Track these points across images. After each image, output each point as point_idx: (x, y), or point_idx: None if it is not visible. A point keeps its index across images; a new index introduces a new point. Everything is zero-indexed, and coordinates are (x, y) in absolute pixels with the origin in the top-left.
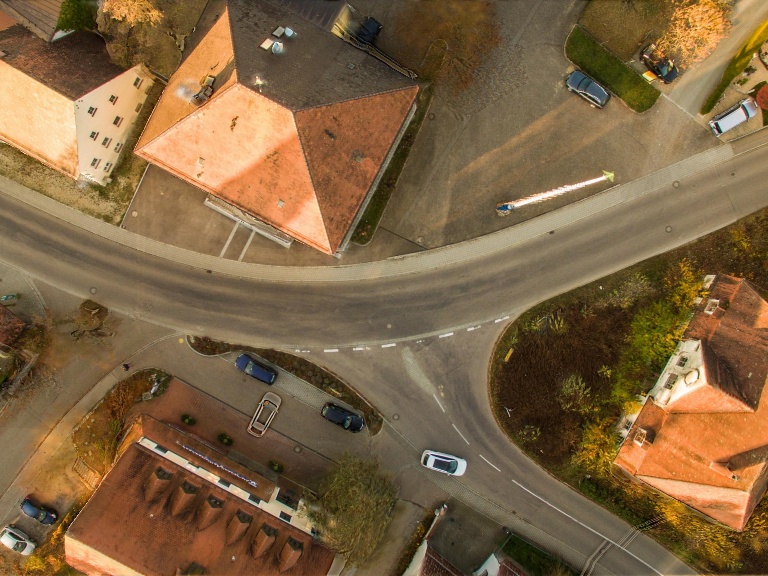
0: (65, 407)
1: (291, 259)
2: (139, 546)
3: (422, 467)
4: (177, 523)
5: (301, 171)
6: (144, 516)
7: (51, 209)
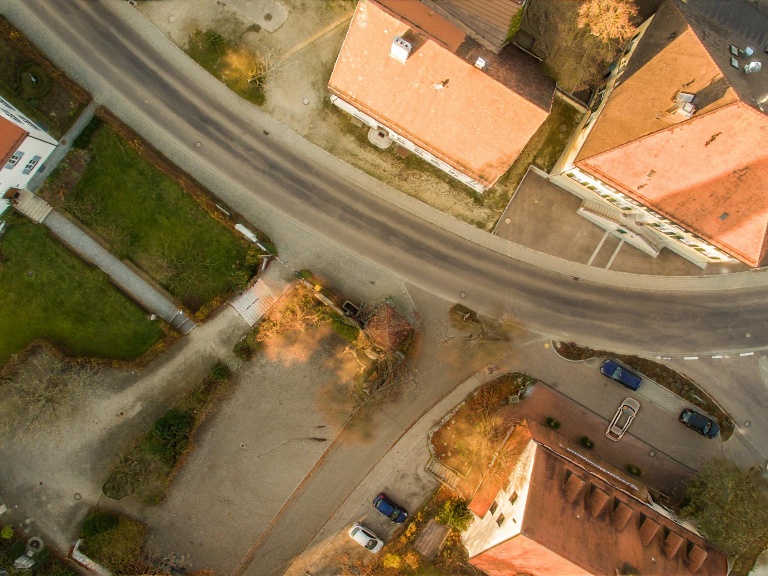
0: (423, 408)
1: (657, 268)
2: (580, 546)
3: (767, 473)
4: (600, 524)
5: (766, 186)
6: (573, 517)
7: (425, 214)
